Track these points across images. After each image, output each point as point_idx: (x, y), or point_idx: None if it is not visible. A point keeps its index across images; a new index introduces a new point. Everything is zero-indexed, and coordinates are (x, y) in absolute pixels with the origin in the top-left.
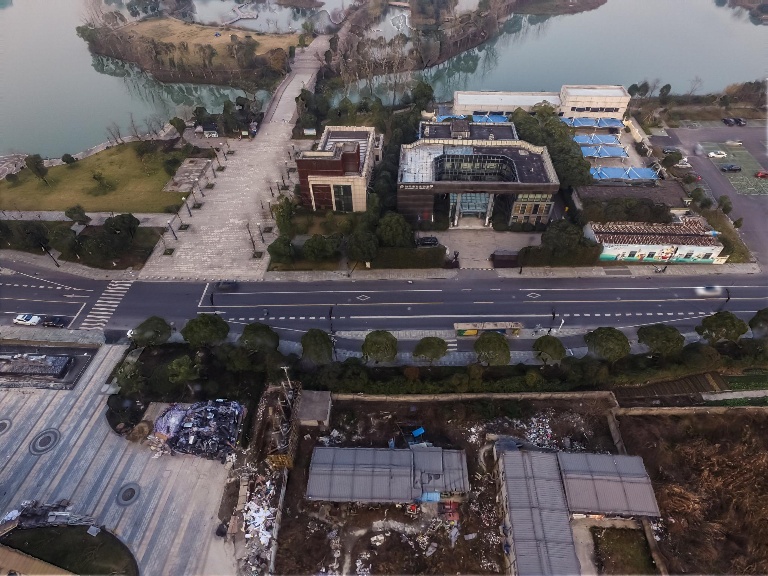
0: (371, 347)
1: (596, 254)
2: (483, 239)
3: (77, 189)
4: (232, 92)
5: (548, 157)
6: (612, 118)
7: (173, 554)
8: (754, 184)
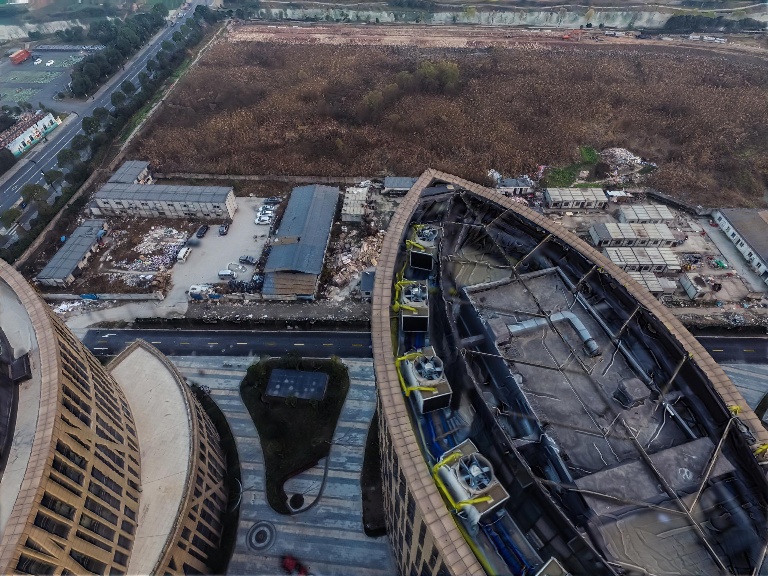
0: None
1: (9, 153)
2: None
3: None
4: None
5: None
6: None
7: None
8: (22, 95)
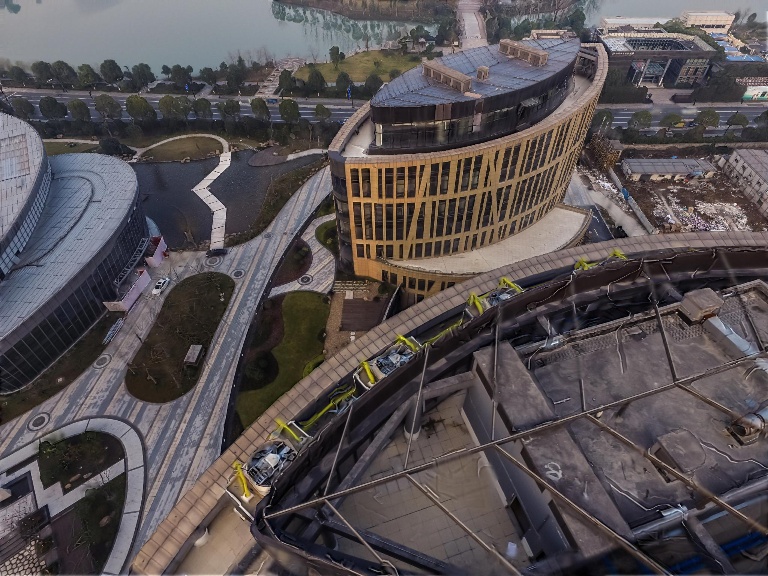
0: (642, 115)
1: (743, 91)
2: (660, 92)
3: (360, 72)
4: (405, 29)
5: (701, 40)
6: (719, 33)
7: (571, 195)
8: None
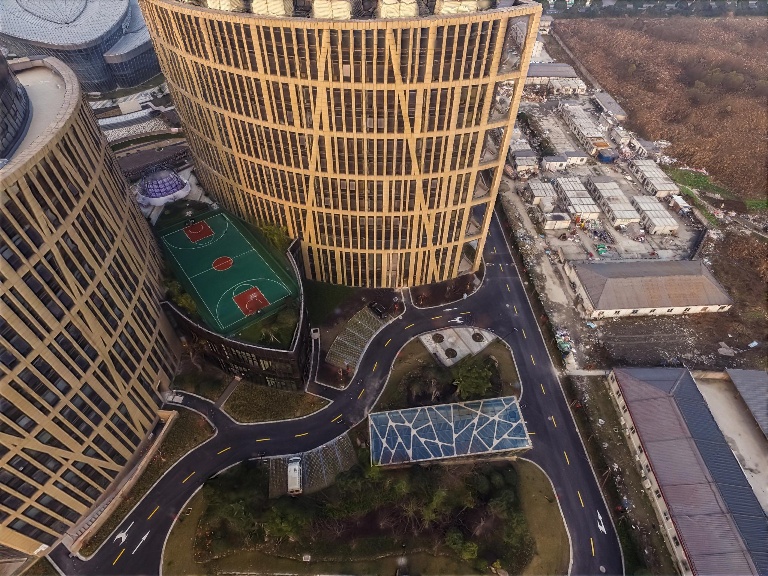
0: None
1: None
2: None
3: None
4: None
5: None
6: None
7: None
8: None
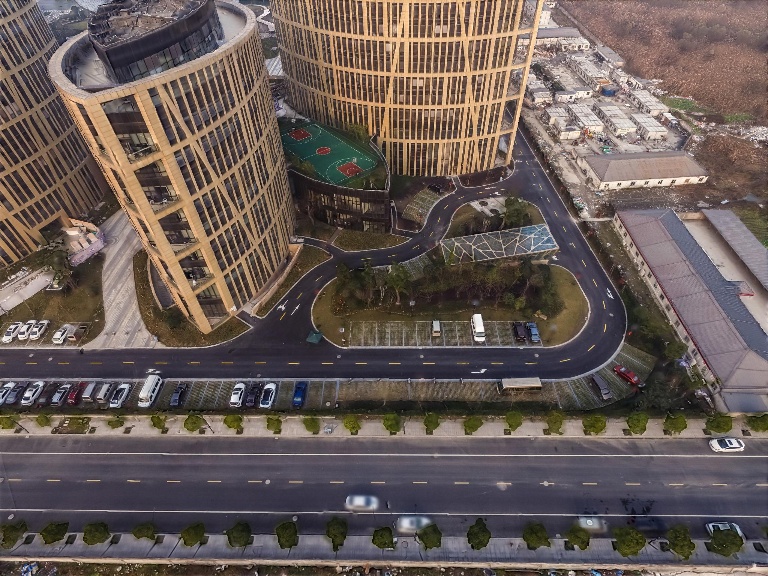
0: None
1: None
2: None
3: None
4: None
5: None
6: None
7: None
8: None
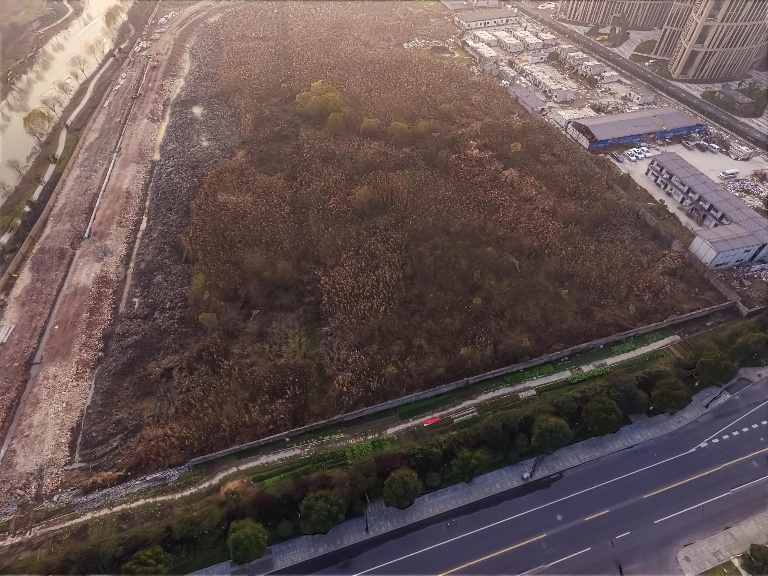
0: None
1: None
2: None
3: None
4: None
5: None
6: None
7: None
8: None
